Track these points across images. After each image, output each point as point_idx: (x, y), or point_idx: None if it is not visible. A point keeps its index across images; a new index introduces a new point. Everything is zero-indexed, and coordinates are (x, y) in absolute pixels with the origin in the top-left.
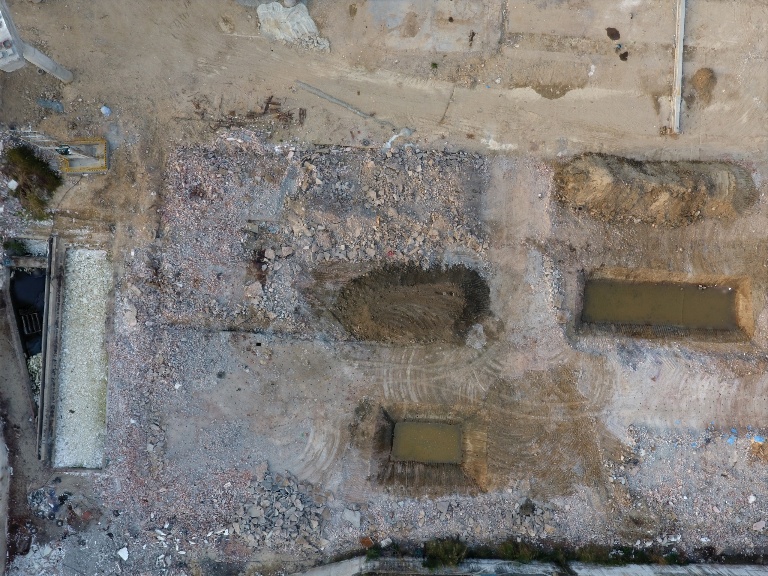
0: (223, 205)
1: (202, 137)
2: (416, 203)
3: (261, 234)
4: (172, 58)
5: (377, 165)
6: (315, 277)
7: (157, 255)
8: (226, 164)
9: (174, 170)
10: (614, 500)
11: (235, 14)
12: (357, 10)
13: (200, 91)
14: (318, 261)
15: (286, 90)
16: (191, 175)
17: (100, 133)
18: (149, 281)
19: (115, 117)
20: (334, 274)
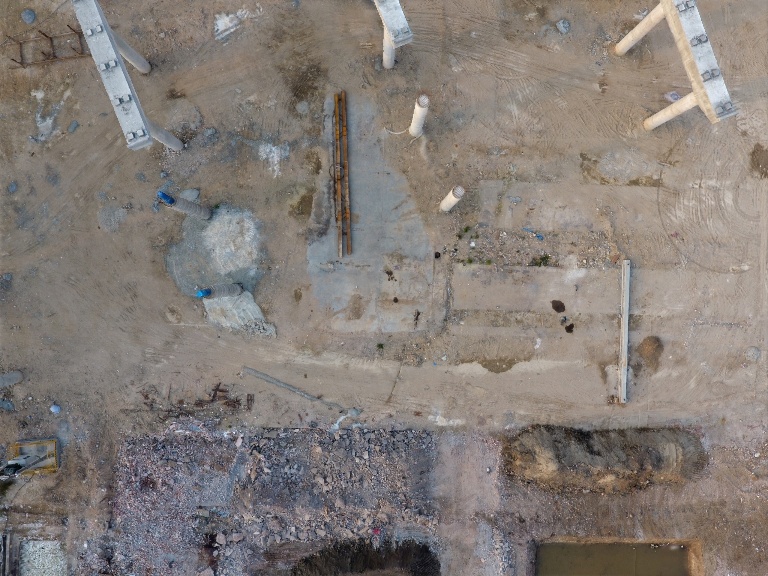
0: (173, 495)
1: (151, 427)
2: (364, 489)
3: (213, 517)
4: (120, 351)
5: (324, 452)
6: (267, 558)
7: (110, 544)
8: (175, 455)
9: (124, 465)
10: None
11: (181, 304)
12: (302, 294)
13: (149, 381)
14: None
15: (234, 376)
16: (141, 467)
17: (50, 431)
18: (102, 571)
19: (65, 414)
20: (285, 554)
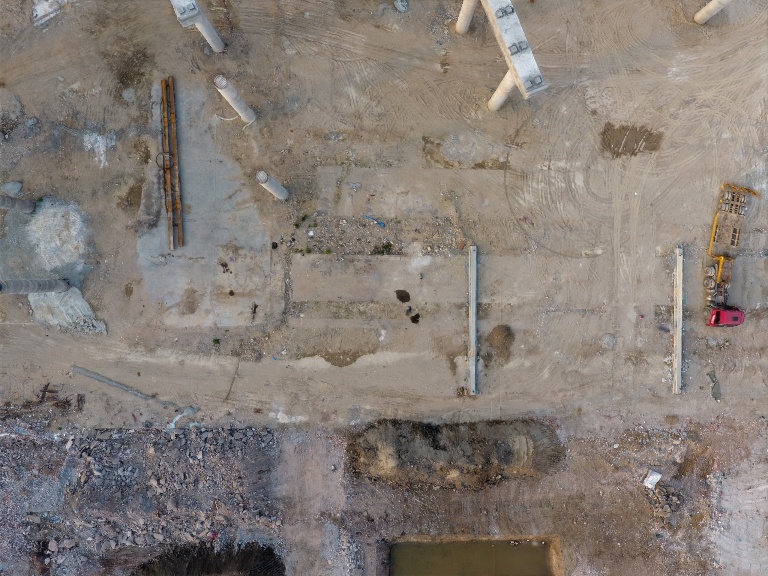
0: (1, 501)
1: None
2: (198, 491)
3: (46, 523)
4: None
5: (157, 452)
6: (103, 564)
7: None
8: (1, 459)
9: None
10: None
11: (6, 302)
12: (133, 289)
13: None
14: (105, 549)
15: (63, 376)
16: None
17: None
18: None
19: None
20: (123, 560)
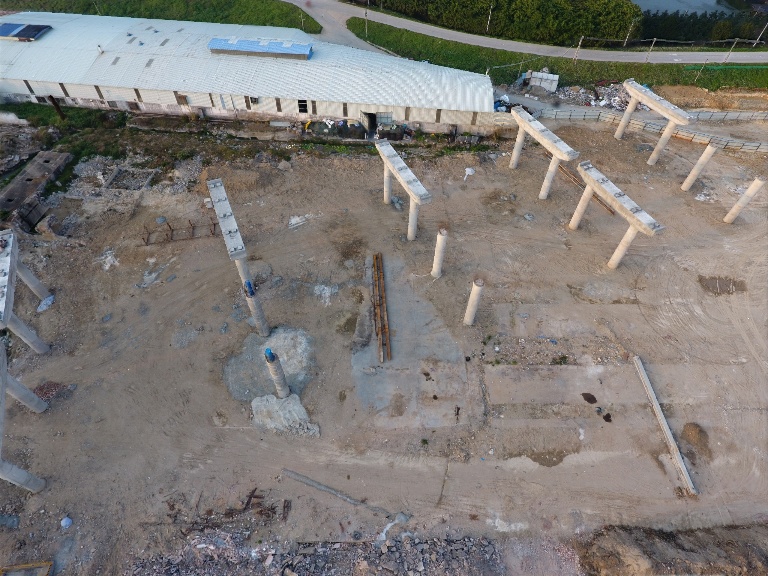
0: None
1: (169, 545)
2: None
3: None
4: (158, 456)
5: (371, 566)
6: None
7: None
8: None
9: None
10: None
11: (230, 408)
12: (346, 395)
13: (179, 489)
14: None
15: (272, 480)
16: None
17: (50, 551)
18: None
19: (75, 529)
20: None
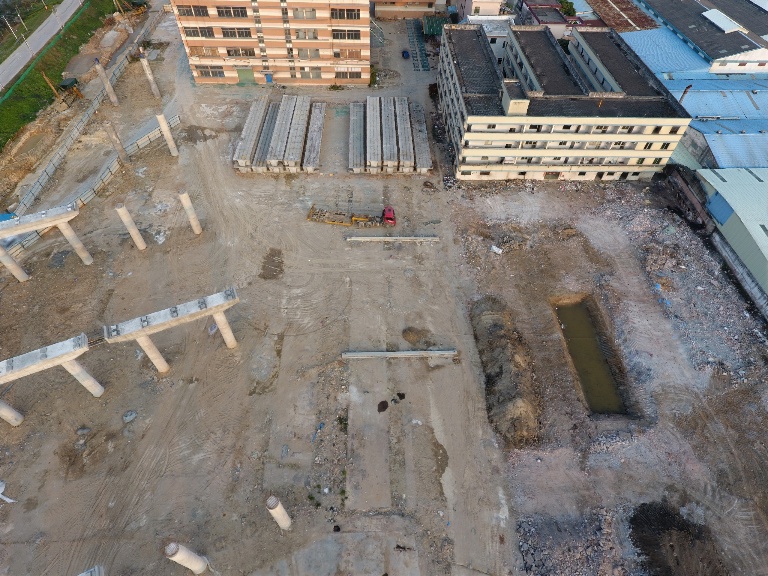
0: None
1: None
2: None
3: None
4: None
5: None
6: None
7: None
8: None
9: None
10: (761, 378)
11: None
12: None
13: None
14: None
15: None
16: None
17: None
18: None
19: None
20: None
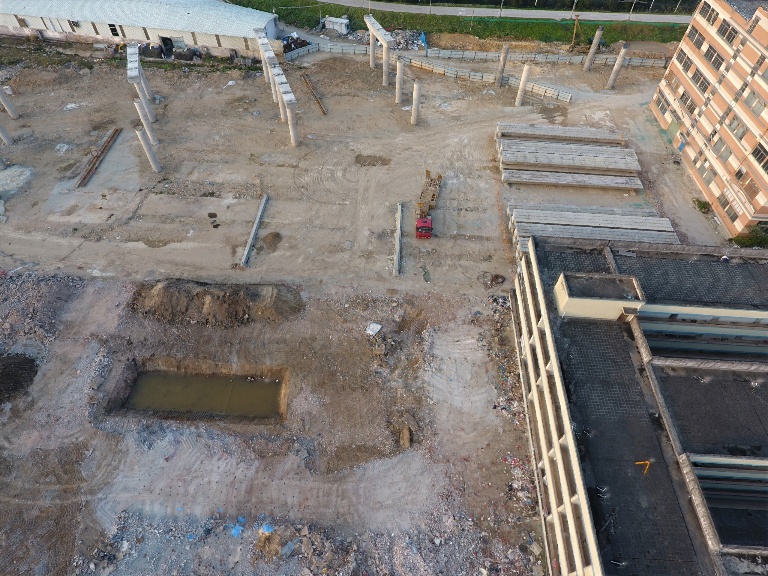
0: None
1: None
2: (2, 304)
3: None
4: None
5: None
6: None
7: None
8: None
9: None
10: None
11: None
12: (39, 204)
13: None
14: None
15: None
16: None
17: None
18: None
19: None
20: None
